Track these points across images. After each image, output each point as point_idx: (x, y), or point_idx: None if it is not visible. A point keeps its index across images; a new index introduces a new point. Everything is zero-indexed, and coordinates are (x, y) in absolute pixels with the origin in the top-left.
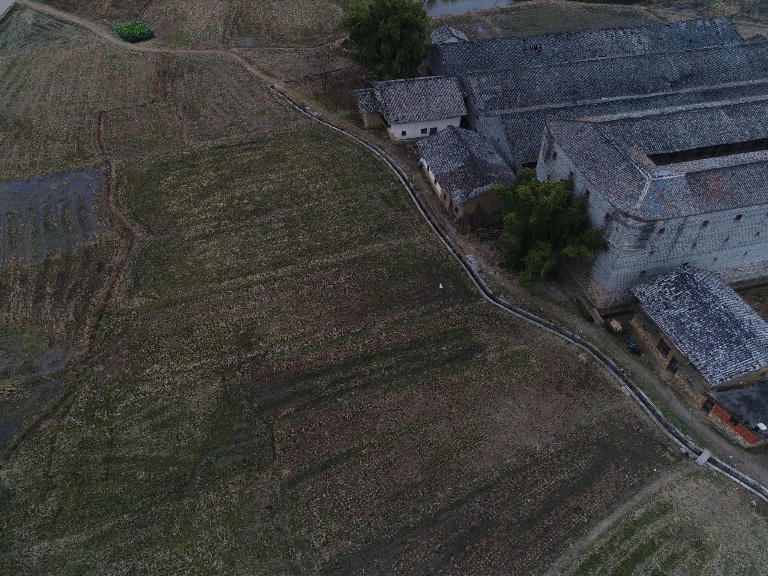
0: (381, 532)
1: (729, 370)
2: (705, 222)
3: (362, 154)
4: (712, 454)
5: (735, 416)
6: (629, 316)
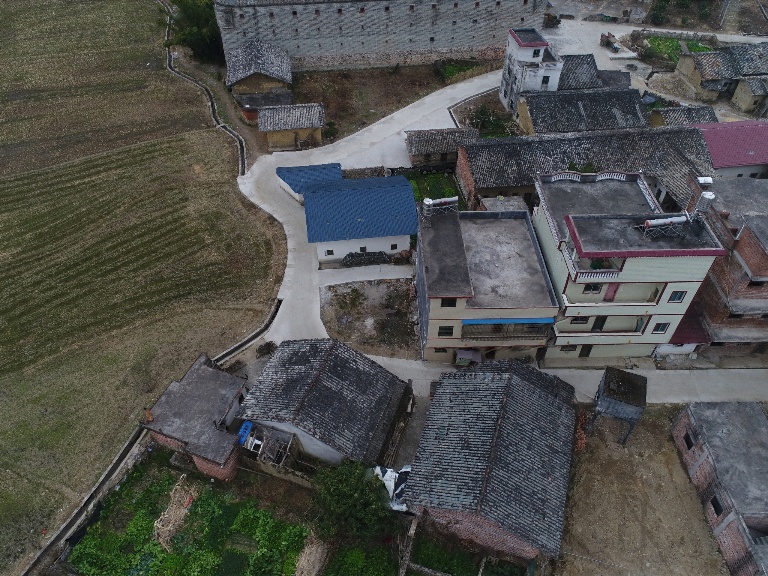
0: (32, 139)
1: (237, 77)
2: (271, 14)
3: (156, 8)
4: (227, 125)
5: (237, 102)
6: None
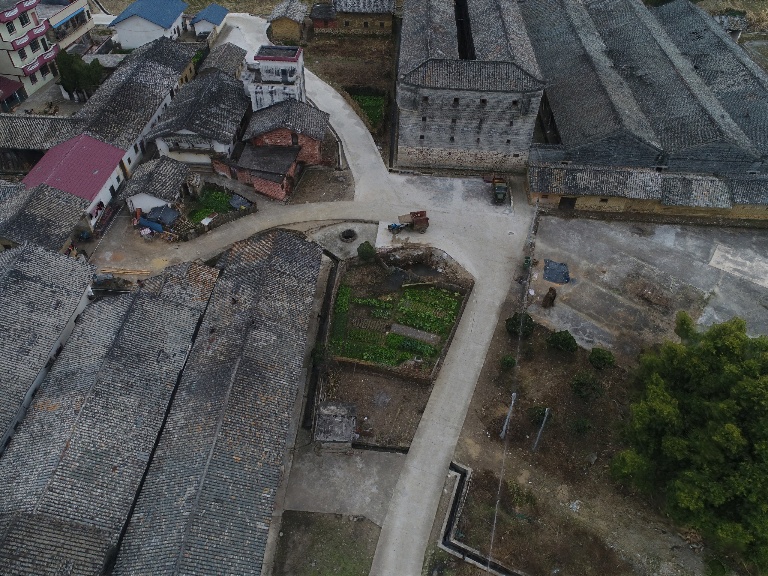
0: None
1: None
2: None
3: None
4: None
5: None
6: (398, 24)
